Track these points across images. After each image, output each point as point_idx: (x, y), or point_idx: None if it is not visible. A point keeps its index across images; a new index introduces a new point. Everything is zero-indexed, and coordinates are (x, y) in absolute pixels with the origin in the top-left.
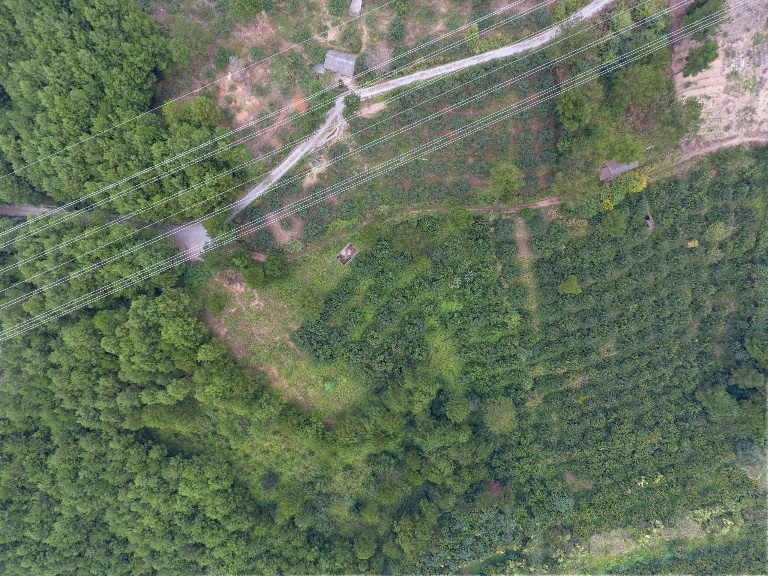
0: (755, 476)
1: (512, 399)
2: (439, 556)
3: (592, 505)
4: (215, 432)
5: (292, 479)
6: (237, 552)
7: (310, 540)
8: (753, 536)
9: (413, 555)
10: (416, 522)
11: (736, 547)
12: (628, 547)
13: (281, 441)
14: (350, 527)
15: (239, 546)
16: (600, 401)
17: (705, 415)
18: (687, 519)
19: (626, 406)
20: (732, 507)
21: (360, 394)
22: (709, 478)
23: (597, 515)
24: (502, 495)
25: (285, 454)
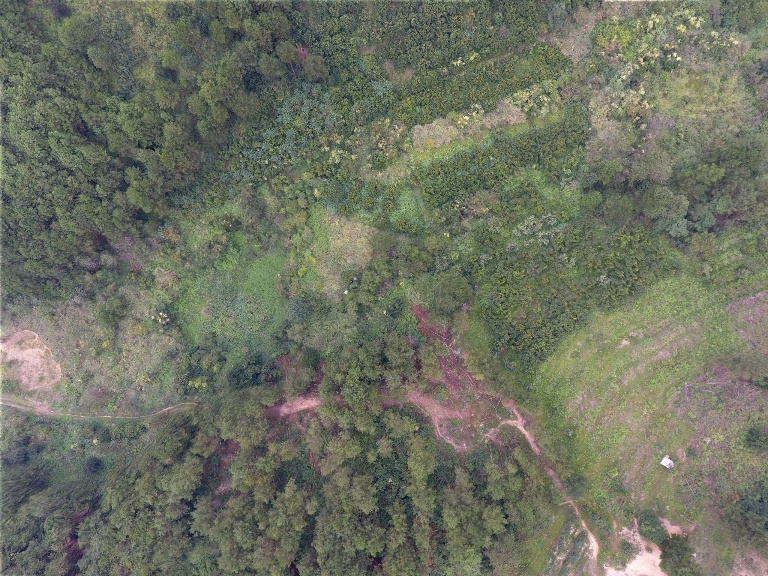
0: (568, 49)
1: None
2: (262, 150)
3: (413, 94)
4: None
5: (87, 20)
6: (24, 70)
7: None
8: (570, 111)
9: (218, 109)
10: (217, 70)
11: (554, 125)
12: (449, 133)
13: None
14: None
15: (25, 62)
16: None
17: None
18: (507, 103)
19: None
20: (549, 85)
21: None
22: (527, 62)
23: (418, 103)
24: None
25: None
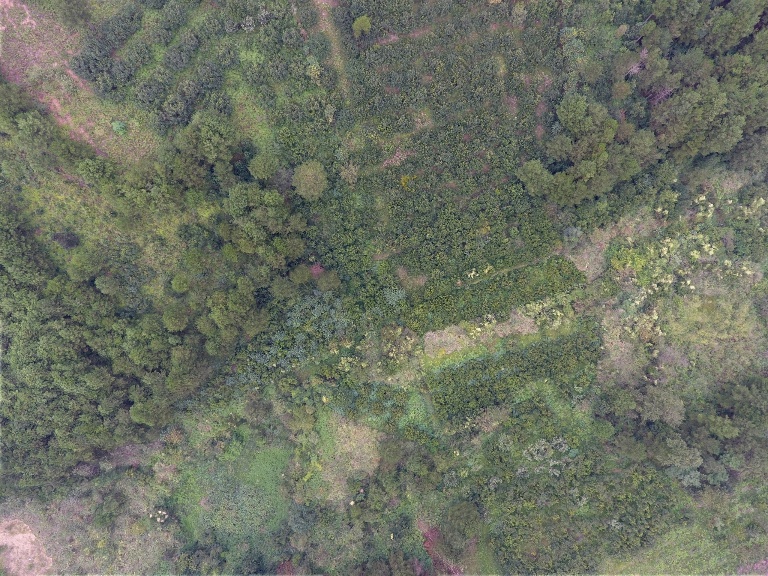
0: (583, 265)
1: (324, 167)
2: (270, 354)
3: (425, 301)
4: (3, 179)
5: (96, 244)
6: (28, 307)
7: (120, 314)
8: (582, 327)
9: (228, 331)
10: (228, 294)
11: (567, 339)
12: (461, 342)
13: (77, 195)
14: (166, 307)
15: (30, 299)
16: (422, 182)
17: (528, 198)
18: (519, 314)
19: (449, 188)
20: (562, 299)
21: (157, 145)
22: (541, 272)
23: (430, 310)
24: (323, 275)
25: (81, 208)
